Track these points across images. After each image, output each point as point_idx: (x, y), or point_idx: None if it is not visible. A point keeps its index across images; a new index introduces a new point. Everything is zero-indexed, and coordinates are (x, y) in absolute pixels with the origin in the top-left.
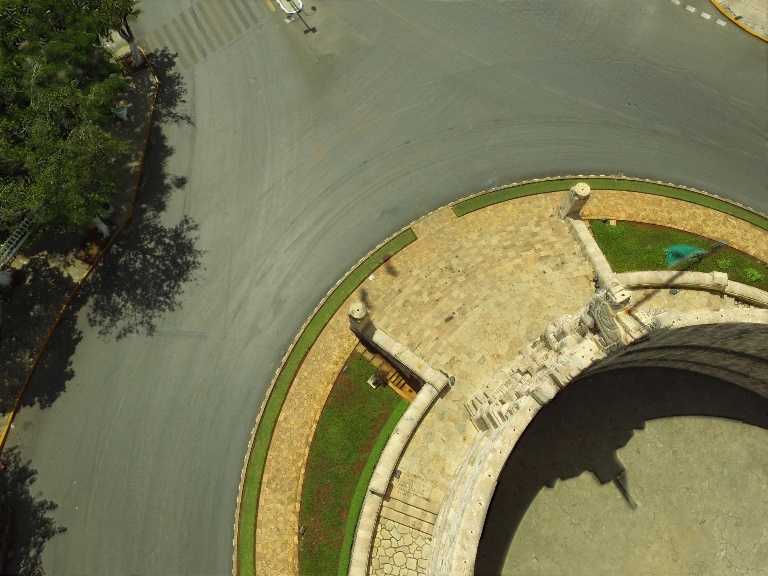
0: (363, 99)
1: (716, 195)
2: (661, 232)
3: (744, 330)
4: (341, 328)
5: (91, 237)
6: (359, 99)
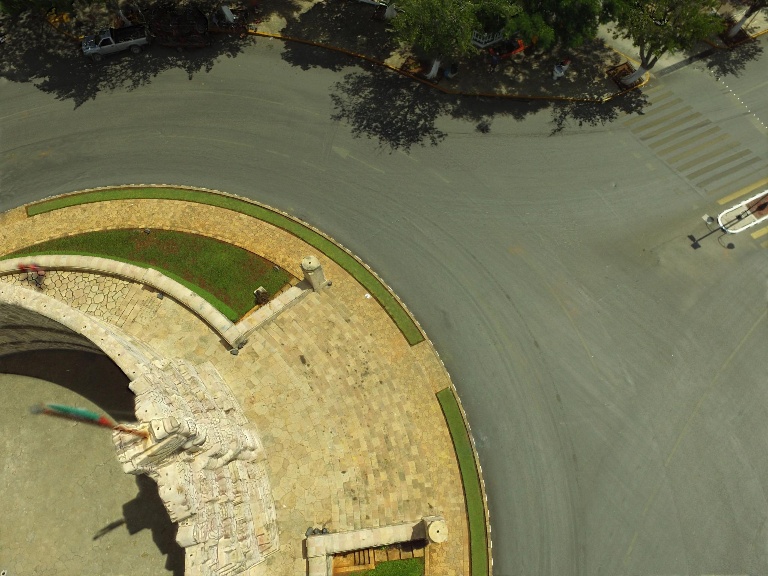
0: (596, 298)
1: None
2: None
3: None
4: None
5: (427, 66)
6: (596, 293)
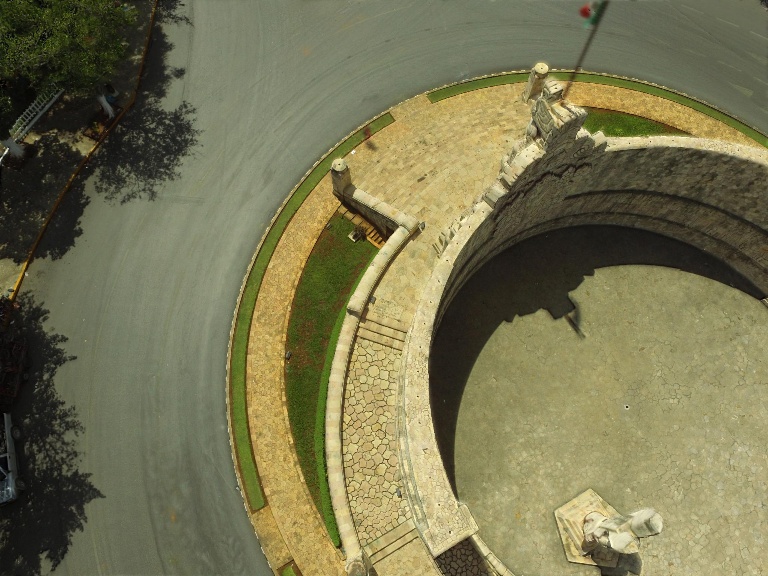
0: (348, 4)
1: (664, 86)
2: (614, 116)
3: (671, 160)
4: (325, 193)
5: (97, 118)
6: (344, 4)
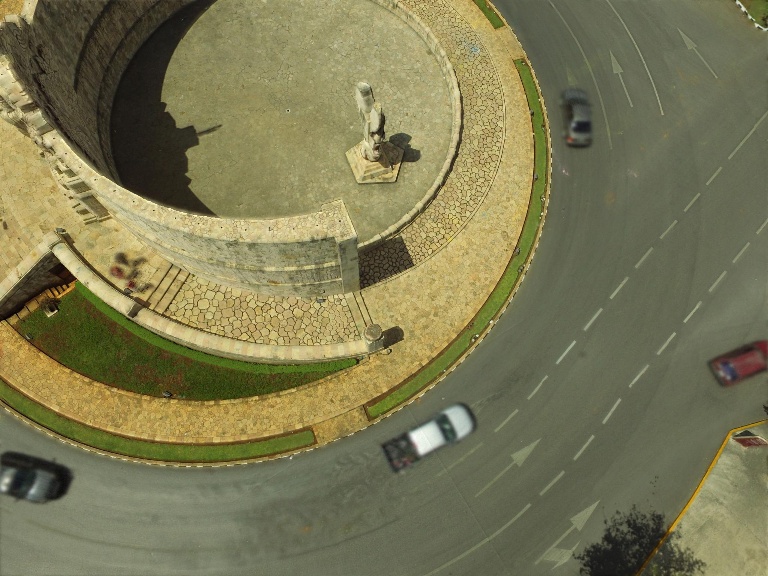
0: None
1: None
2: None
3: None
4: None
5: None
6: None
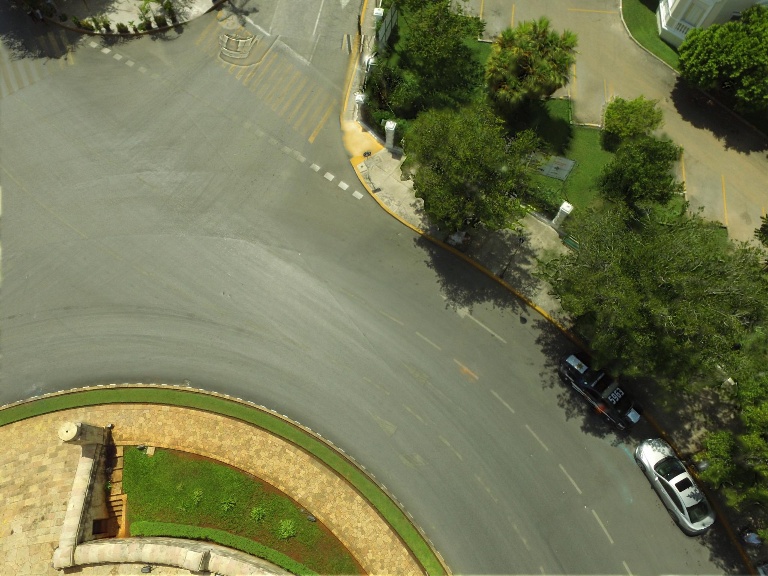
0: None
1: (285, 416)
2: (202, 466)
3: None
4: None
5: None
6: None
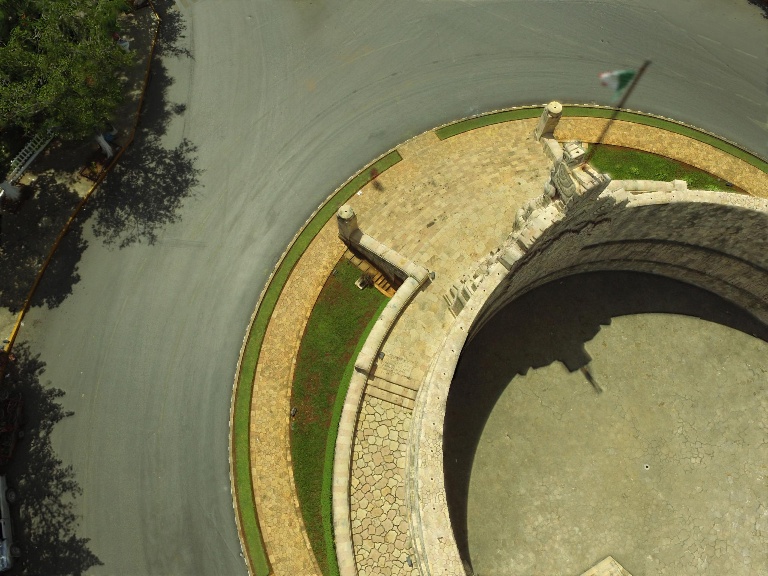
0: (353, 35)
1: (681, 122)
2: (629, 153)
3: (695, 214)
4: (331, 237)
5: (96, 157)
6: (349, 35)
